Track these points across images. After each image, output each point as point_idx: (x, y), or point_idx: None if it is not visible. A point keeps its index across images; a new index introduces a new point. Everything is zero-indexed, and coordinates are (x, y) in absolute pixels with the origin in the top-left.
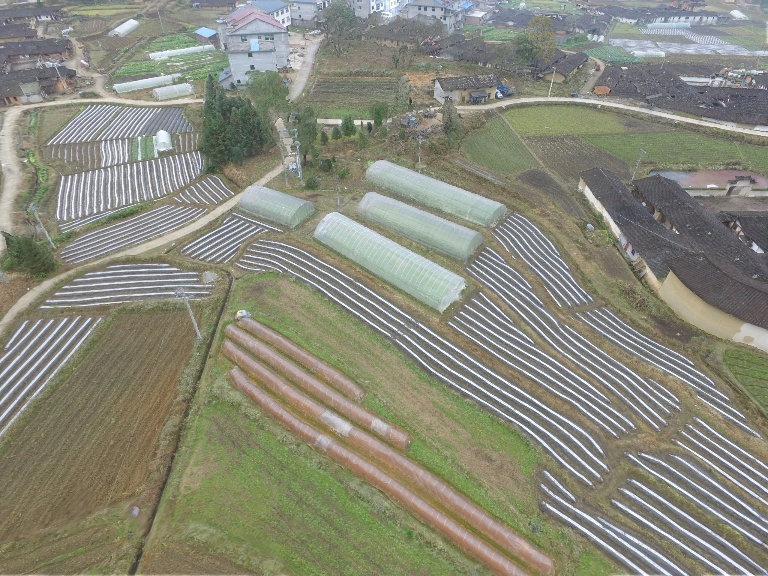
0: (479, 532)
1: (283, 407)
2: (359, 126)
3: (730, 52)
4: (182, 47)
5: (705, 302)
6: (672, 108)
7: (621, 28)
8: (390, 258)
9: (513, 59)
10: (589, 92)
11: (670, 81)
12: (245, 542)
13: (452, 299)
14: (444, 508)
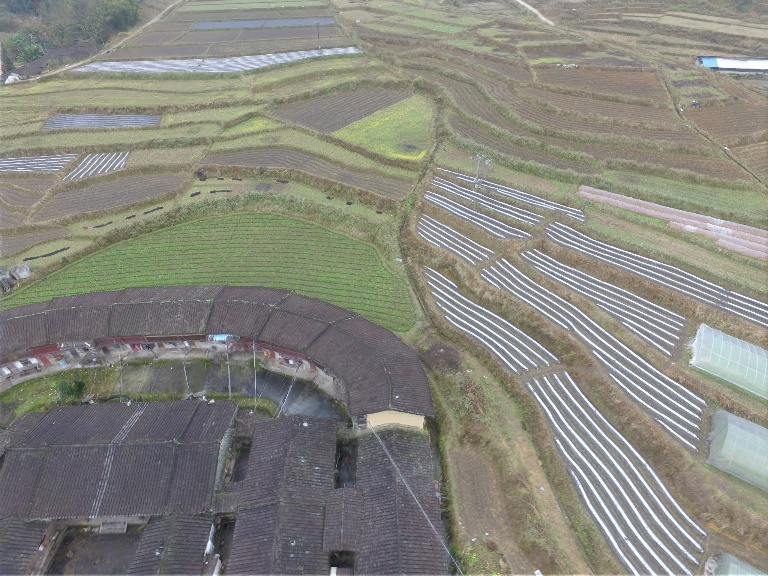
0: None
1: (762, 234)
2: None
3: None
4: None
5: None
6: None
7: None
8: None
9: None
10: None
11: None
12: (719, 185)
13: None
14: None
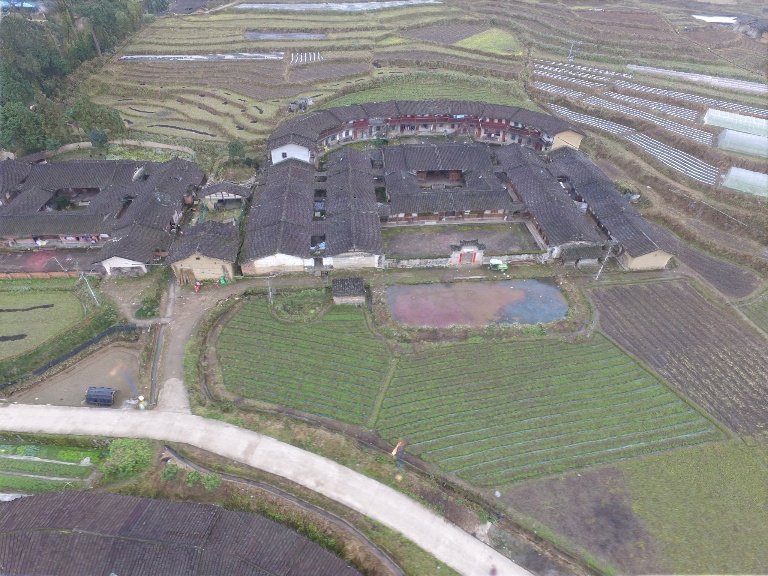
0: None
1: None
2: None
3: None
4: None
5: None
6: None
7: None
8: None
9: None
10: None
11: None
12: (708, 63)
13: None
14: None
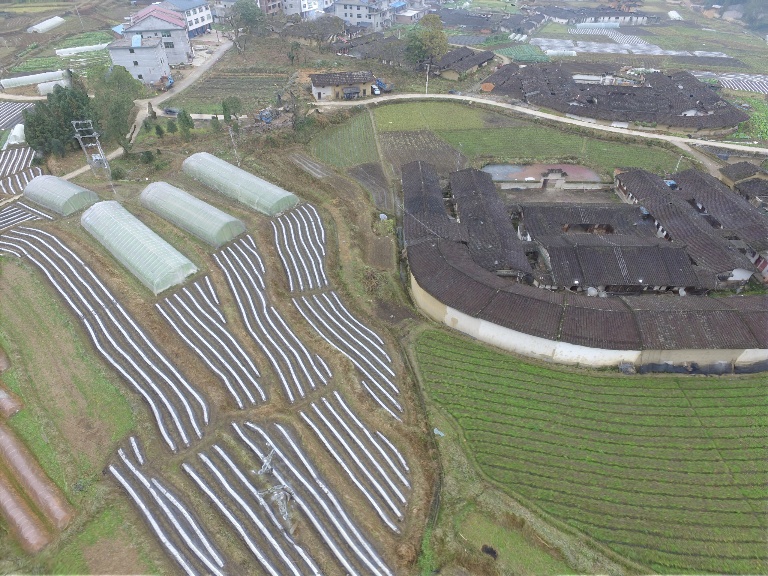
0: (23, 491)
1: None
2: (221, 121)
3: (643, 51)
4: (94, 44)
5: (419, 285)
6: (541, 105)
7: (550, 28)
8: (129, 243)
9: (403, 56)
10: (474, 89)
11: (558, 79)
12: None
13: (173, 282)
14: (6, 470)
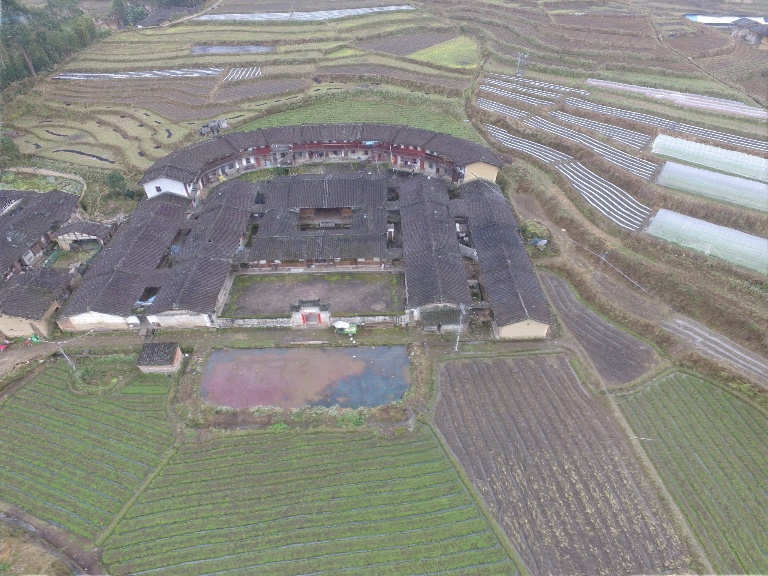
0: None
1: None
2: None
3: None
4: None
5: None
6: None
7: None
8: None
9: None
10: None
11: None
12: (681, 76)
13: None
14: None
